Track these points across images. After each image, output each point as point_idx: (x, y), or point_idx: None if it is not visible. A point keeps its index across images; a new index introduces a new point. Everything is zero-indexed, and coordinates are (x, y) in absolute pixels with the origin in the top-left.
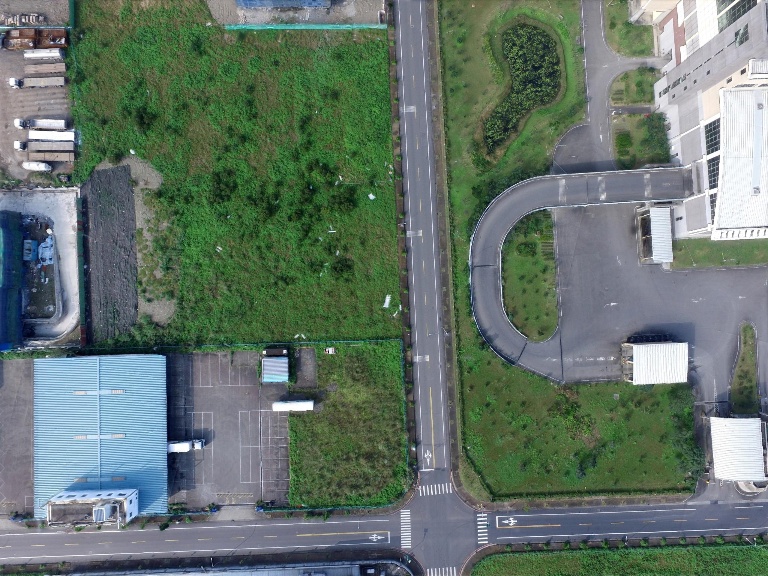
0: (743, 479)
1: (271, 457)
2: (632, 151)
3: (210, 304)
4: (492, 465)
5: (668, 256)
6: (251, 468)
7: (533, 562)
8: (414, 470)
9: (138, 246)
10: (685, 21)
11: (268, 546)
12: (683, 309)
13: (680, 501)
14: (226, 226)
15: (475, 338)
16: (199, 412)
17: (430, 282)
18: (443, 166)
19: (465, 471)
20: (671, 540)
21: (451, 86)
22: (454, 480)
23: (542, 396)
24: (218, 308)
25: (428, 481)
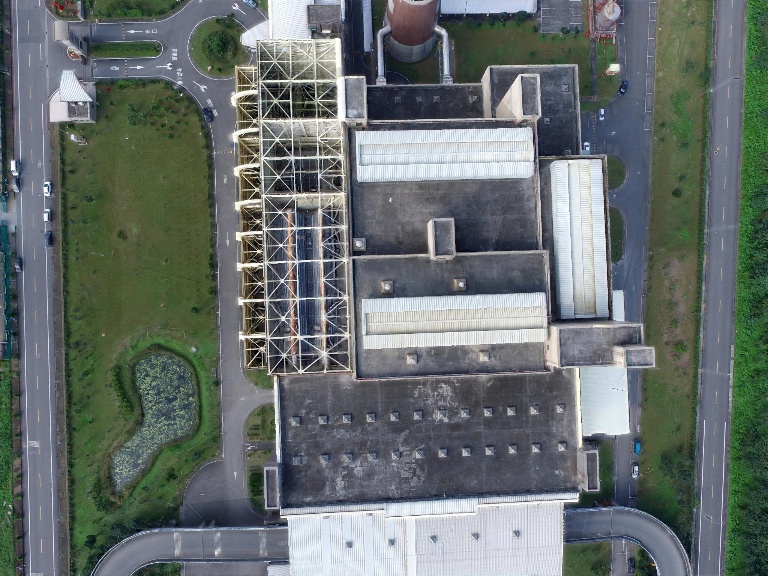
0: None
1: None
2: None
3: None
4: None
5: None
6: None
7: None
8: None
9: None
10: None
11: None
12: None
13: None
14: None
15: None
16: None
17: None
18: (67, 504)
19: None
20: None
21: (78, 420)
22: None
23: None
24: None
25: None
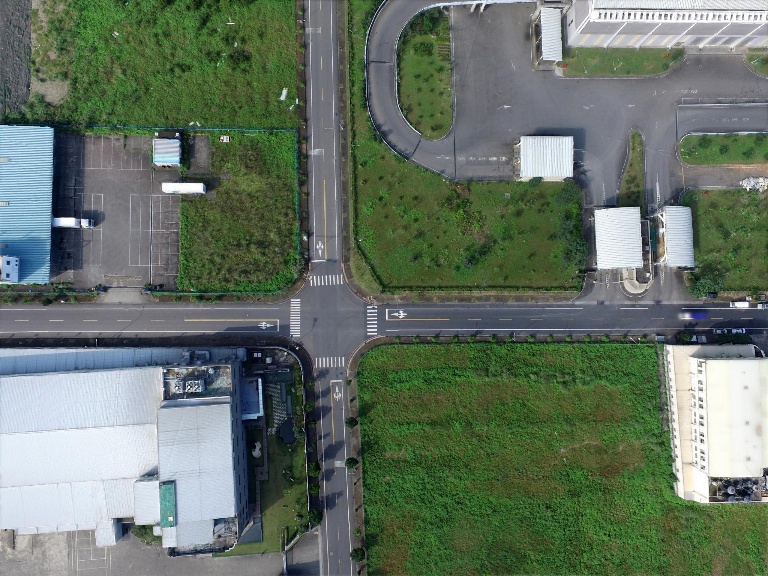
0: (622, 266)
1: (161, 241)
2: None
3: (105, 88)
4: (383, 258)
5: (557, 55)
6: (140, 251)
7: (421, 354)
8: (305, 259)
9: (33, 26)
10: None
11: (155, 330)
12: (574, 114)
13: (567, 300)
14: (123, 12)
15: (368, 129)
16: (89, 194)
17: (327, 78)
18: None
19: (356, 263)
20: (558, 337)
21: None
22: (345, 272)
23: (434, 192)
24: (112, 91)
25: (319, 272)
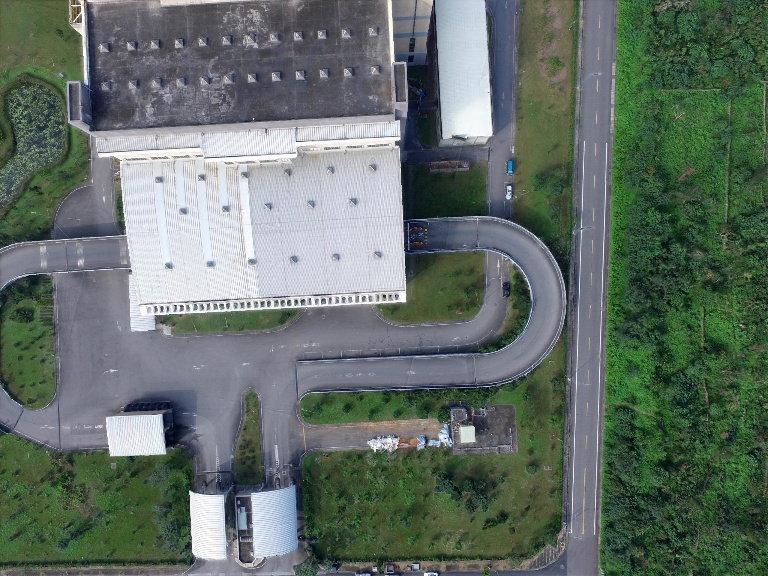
0: (206, 557)
1: None
2: None
3: None
4: None
5: (148, 324)
6: None
7: None
8: None
9: None
10: None
11: None
12: (184, 376)
13: (180, 573)
14: None
15: None
16: None
17: None
18: None
19: None
20: None
21: None
22: None
23: (37, 464)
24: None
25: None
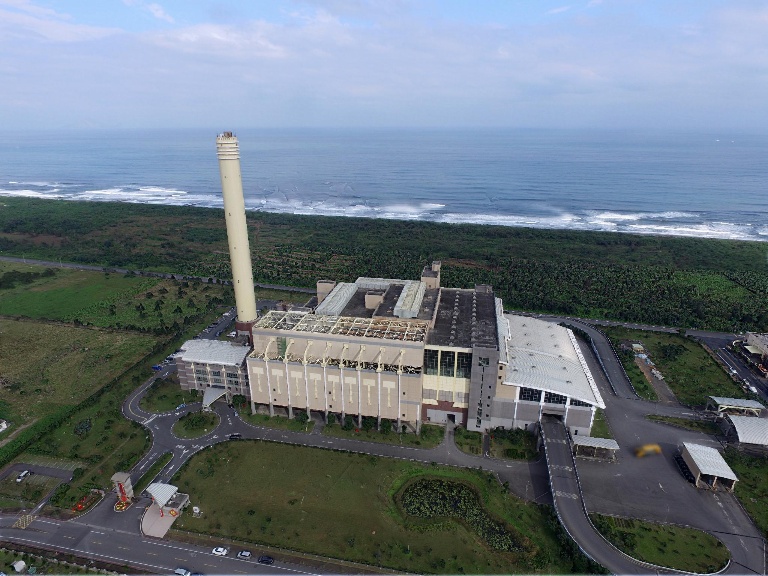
0: None
1: None
2: (520, 450)
3: None
4: None
5: (611, 441)
6: None
7: None
8: None
9: None
10: (438, 399)
11: None
12: (648, 446)
13: None
14: None
15: None
16: None
17: None
18: None
19: None
20: None
21: (452, 572)
22: None
23: None
24: None
25: None
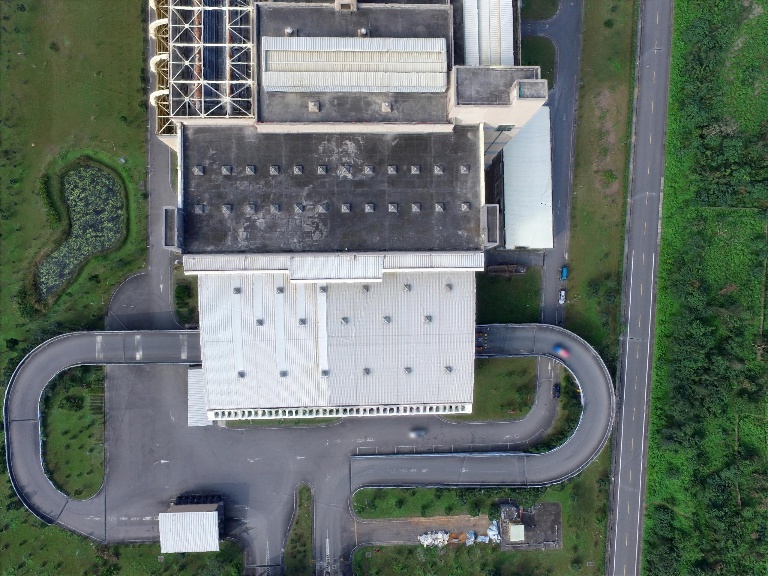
0: None
1: None
2: (192, 303)
3: None
4: None
5: (206, 419)
6: None
7: None
8: None
9: None
10: None
11: None
12: (237, 469)
13: None
14: None
15: (3, 498)
16: None
17: None
18: None
19: None
20: None
21: (5, 228)
22: None
23: (81, 557)
24: None
25: None
